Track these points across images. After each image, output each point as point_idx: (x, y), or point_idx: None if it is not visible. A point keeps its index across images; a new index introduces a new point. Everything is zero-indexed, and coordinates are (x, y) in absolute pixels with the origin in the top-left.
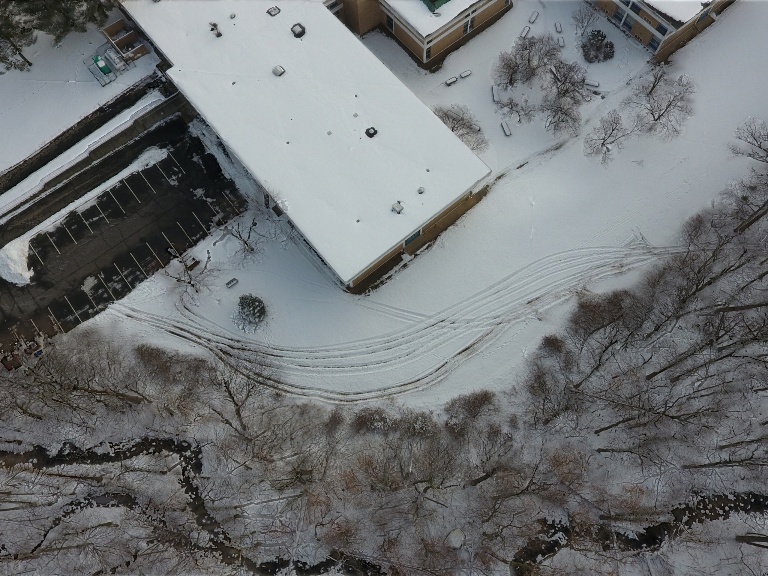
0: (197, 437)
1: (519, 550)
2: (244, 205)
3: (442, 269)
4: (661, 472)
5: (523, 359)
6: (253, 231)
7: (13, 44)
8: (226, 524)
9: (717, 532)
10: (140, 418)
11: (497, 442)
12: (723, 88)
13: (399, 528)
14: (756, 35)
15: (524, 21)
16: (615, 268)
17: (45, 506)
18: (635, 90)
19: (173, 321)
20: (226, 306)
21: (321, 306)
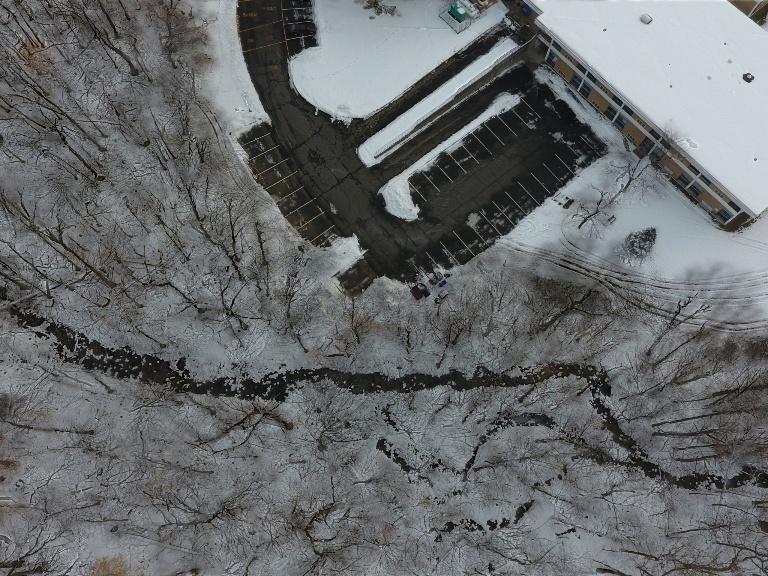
0: (603, 362)
1: None
2: (604, 148)
3: None
4: None
5: None
6: None
7: None
8: (643, 441)
9: None
10: (547, 344)
11: None
12: None
13: None
14: None
15: None
16: None
17: (475, 424)
18: None
19: (561, 255)
20: (609, 241)
21: (699, 242)
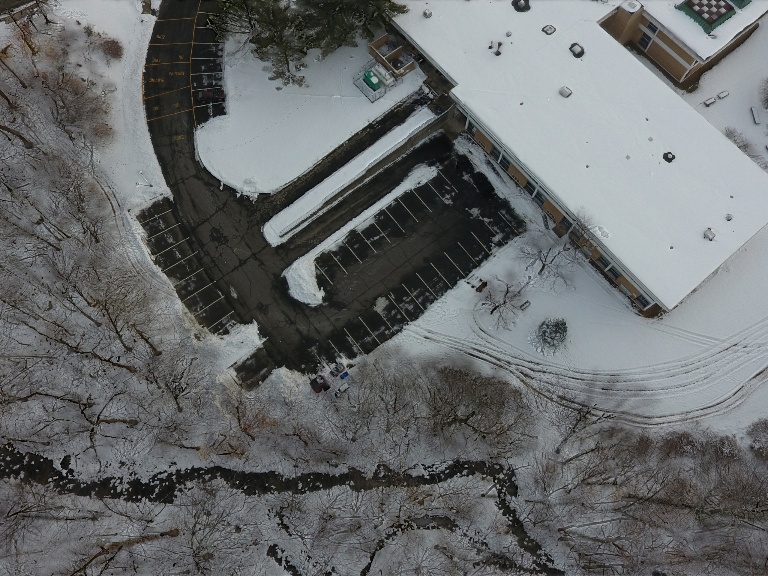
0: (510, 460)
1: None
2: (522, 225)
3: (730, 293)
4: None
5: None
6: None
7: (286, 58)
8: (549, 546)
9: None
10: (452, 441)
11: None
12: None
13: None
14: None
15: None
16: None
17: (372, 529)
18: None
19: (471, 343)
20: (522, 328)
21: (616, 329)
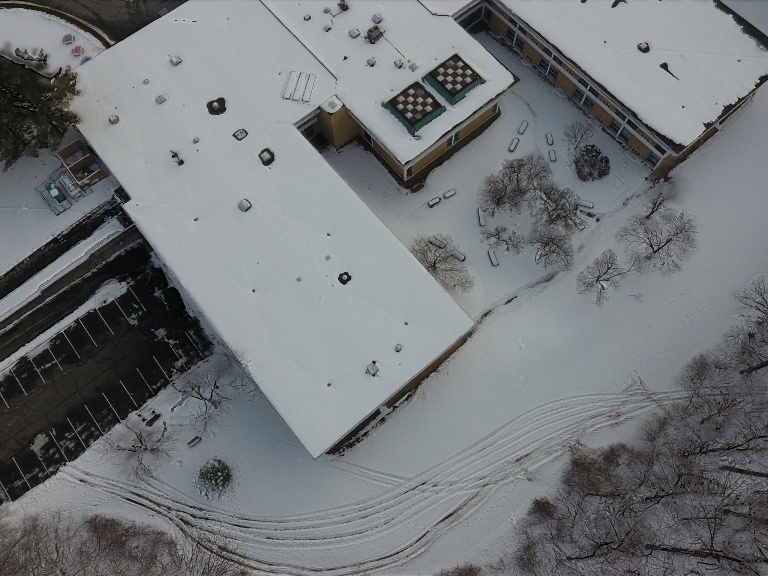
0: None
1: None
2: (209, 348)
3: (423, 424)
4: None
5: (511, 526)
6: (218, 381)
7: None
8: None
9: None
10: None
11: None
12: (727, 208)
13: None
14: (762, 146)
15: (513, 132)
16: (611, 418)
17: None
18: (632, 222)
19: (130, 486)
20: (188, 468)
21: (291, 468)
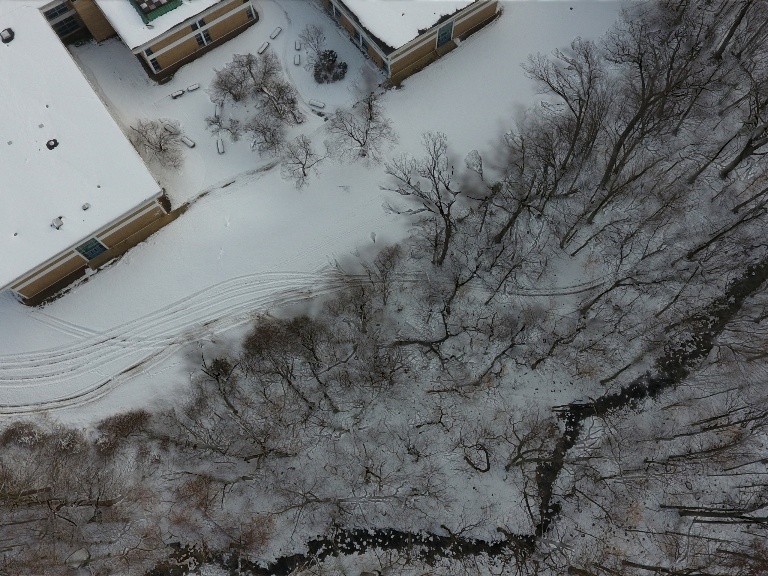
0: None
1: (147, 573)
2: None
3: (122, 286)
4: (303, 503)
5: (189, 381)
6: None
7: None
8: None
9: (342, 567)
10: None
11: (144, 463)
12: (450, 116)
13: (22, 544)
14: (496, 64)
15: (265, 36)
16: (303, 294)
17: None
18: None
19: None
20: None
21: None
